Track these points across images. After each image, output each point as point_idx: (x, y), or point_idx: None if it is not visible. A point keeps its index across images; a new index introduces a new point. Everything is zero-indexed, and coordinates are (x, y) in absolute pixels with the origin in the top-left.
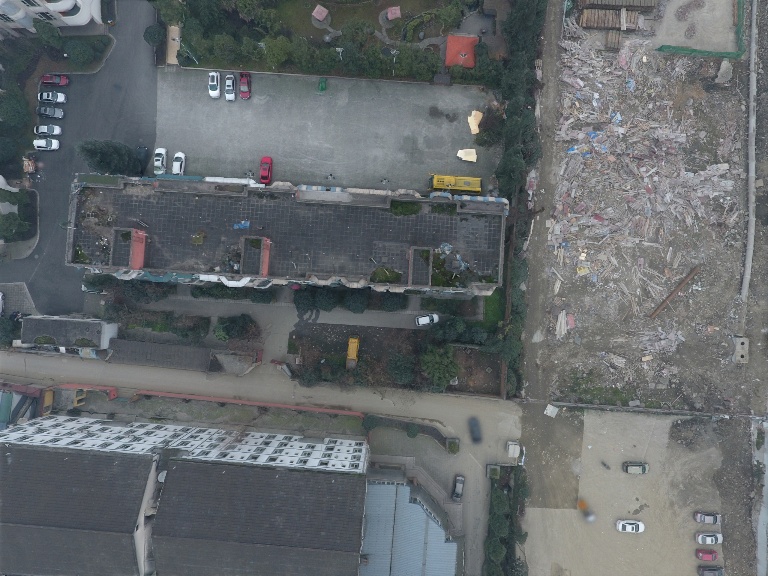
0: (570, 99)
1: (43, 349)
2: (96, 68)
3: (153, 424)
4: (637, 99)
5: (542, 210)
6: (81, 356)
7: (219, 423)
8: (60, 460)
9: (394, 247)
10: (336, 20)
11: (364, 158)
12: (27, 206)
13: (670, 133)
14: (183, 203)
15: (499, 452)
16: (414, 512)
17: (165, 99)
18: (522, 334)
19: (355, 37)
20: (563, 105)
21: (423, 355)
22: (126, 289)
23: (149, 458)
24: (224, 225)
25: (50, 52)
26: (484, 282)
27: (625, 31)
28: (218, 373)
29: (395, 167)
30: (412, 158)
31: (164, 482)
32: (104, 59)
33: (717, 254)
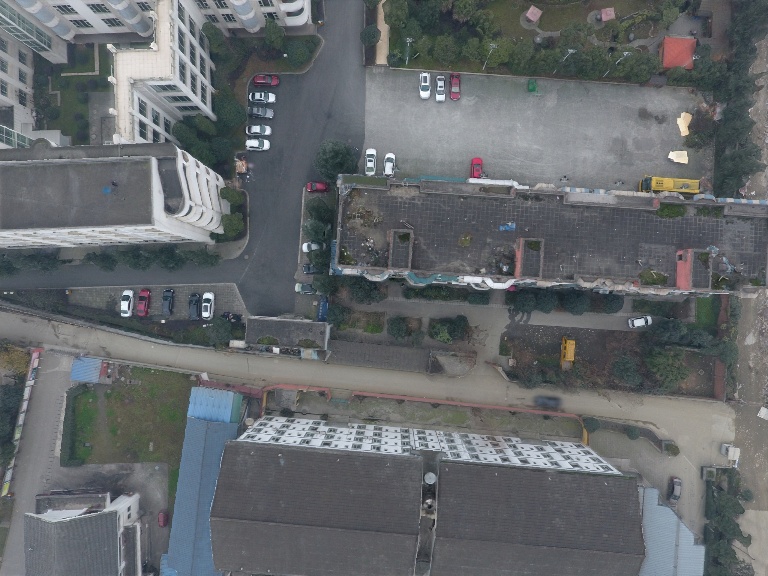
0: None
1: (255, 349)
2: (305, 68)
3: (369, 425)
4: None
5: None
6: (302, 357)
7: (432, 424)
8: (332, 461)
9: (660, 249)
10: (544, 21)
11: (573, 159)
12: (240, 206)
13: None
14: (448, 205)
15: (713, 454)
16: (663, 514)
17: (373, 100)
18: None
19: (576, 38)
20: None
21: (654, 357)
22: (355, 290)
23: (419, 460)
24: (490, 227)
25: (260, 52)
26: None
27: None
28: (440, 374)
29: (604, 169)
30: (621, 160)
31: (439, 484)
32: (313, 59)
33: None
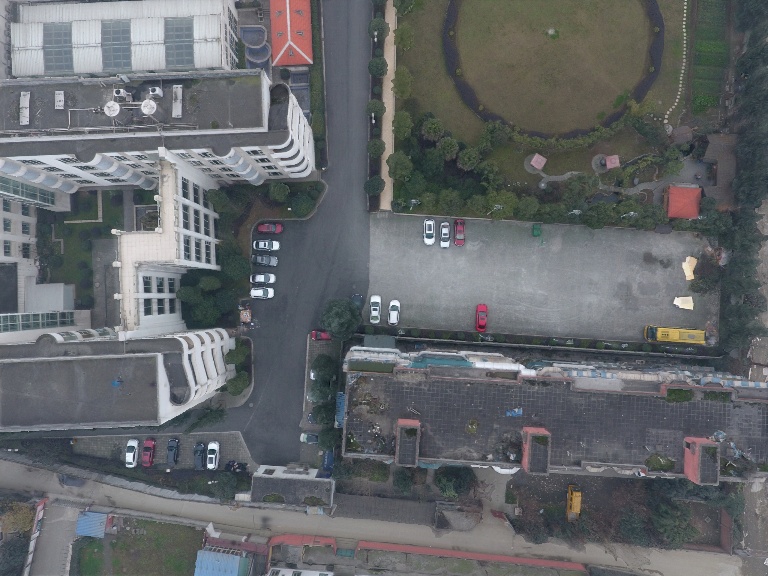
0: None
1: None
2: (309, 214)
3: None
4: None
5: None
6: (308, 512)
7: (438, 574)
8: None
9: (667, 434)
10: (549, 165)
11: (578, 305)
12: (245, 357)
13: None
14: (455, 390)
15: None
16: None
17: (378, 245)
18: None
19: (580, 191)
20: None
21: (661, 518)
22: None
23: None
24: (496, 412)
25: (263, 199)
26: (758, 470)
27: None
28: (446, 530)
29: (610, 314)
30: (626, 304)
31: None
32: (317, 205)
33: None
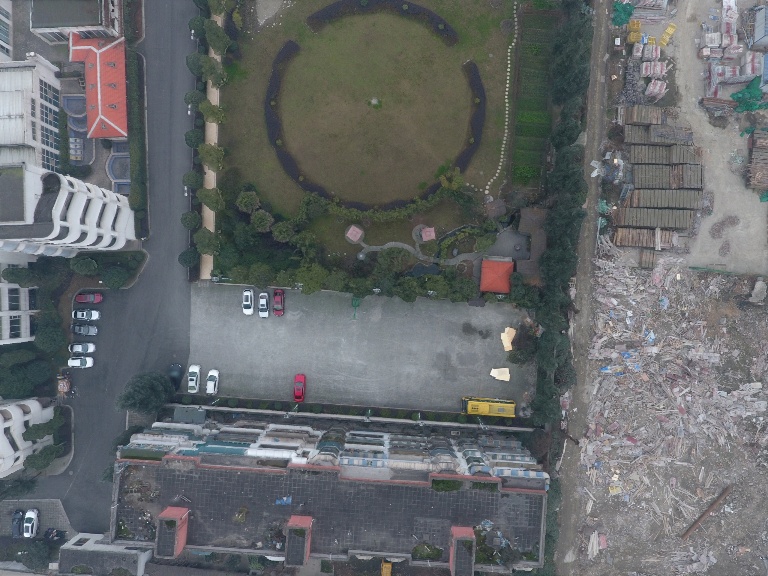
0: (604, 319)
1: None
2: (130, 284)
3: None
4: (670, 317)
5: (577, 443)
6: None
7: None
8: None
9: (435, 523)
10: (369, 235)
11: (397, 375)
12: (62, 426)
13: (703, 353)
14: (225, 478)
15: None
16: None
17: (198, 314)
18: (554, 555)
19: (390, 265)
20: (597, 325)
21: None
22: None
23: None
24: (266, 500)
25: None
26: (525, 559)
27: (659, 249)
28: None
29: (428, 384)
30: (445, 375)
31: None
32: (137, 274)
33: (749, 474)
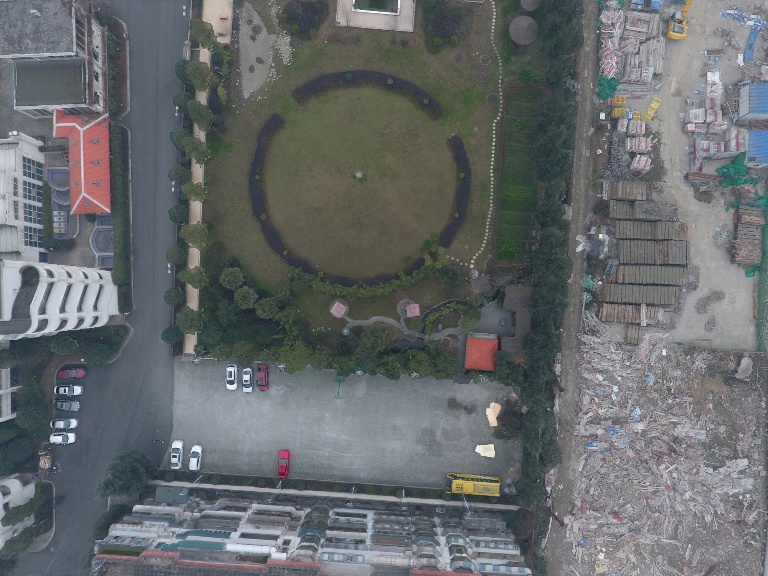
0: (589, 395)
1: None
2: (113, 358)
3: None
4: (656, 392)
5: (562, 525)
6: None
7: None
8: None
9: None
10: (354, 309)
11: (382, 450)
12: (43, 503)
13: (690, 430)
14: (204, 574)
15: None
16: None
17: (182, 389)
18: None
19: (374, 344)
20: (582, 401)
21: None
22: None
23: None
24: None
25: None
26: None
27: None
28: None
29: (413, 460)
30: (430, 450)
31: None
32: (121, 349)
33: (736, 552)
